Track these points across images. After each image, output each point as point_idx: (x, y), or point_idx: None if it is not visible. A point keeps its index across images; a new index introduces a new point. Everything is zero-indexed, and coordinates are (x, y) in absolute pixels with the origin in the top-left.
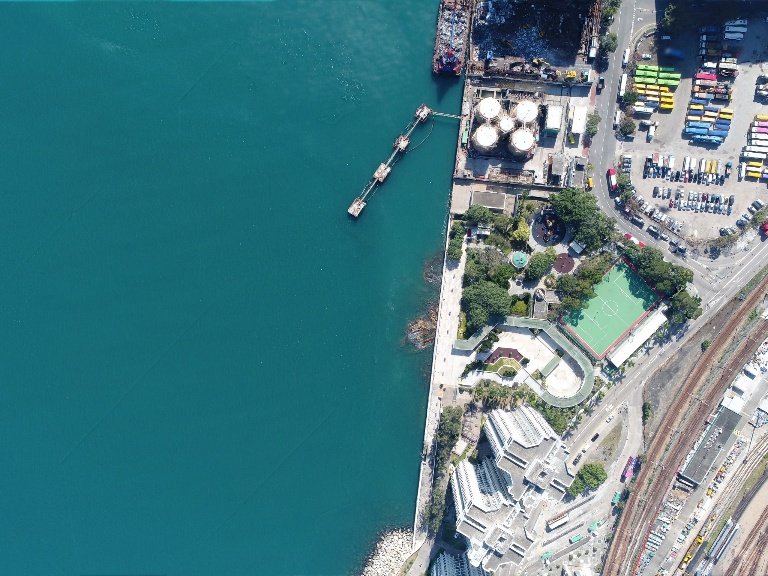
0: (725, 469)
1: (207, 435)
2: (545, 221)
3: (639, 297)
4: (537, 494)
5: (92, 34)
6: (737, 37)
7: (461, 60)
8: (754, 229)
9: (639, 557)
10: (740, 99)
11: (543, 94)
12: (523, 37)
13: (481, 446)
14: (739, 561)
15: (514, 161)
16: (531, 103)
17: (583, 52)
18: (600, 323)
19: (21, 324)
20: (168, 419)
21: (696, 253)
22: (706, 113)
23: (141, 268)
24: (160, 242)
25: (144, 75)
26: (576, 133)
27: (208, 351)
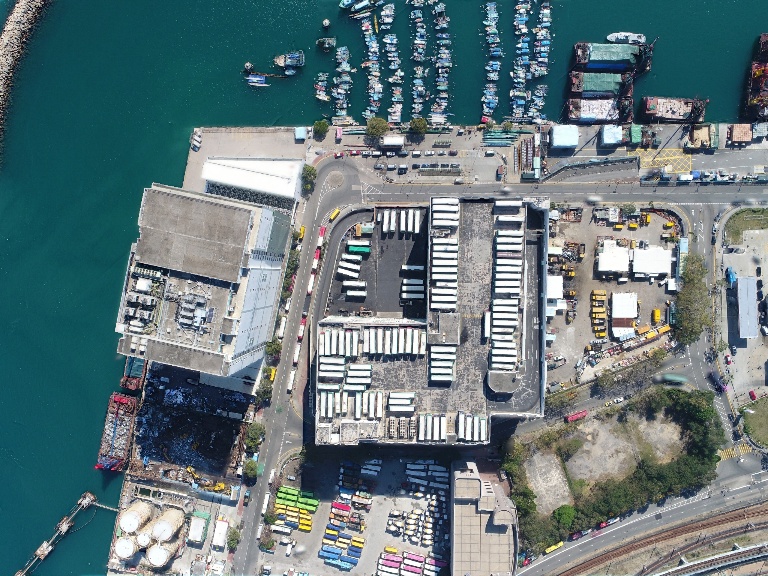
0: None
1: None
2: None
3: None
4: None
5: None
6: None
7: (123, 458)
8: None
9: None
10: (373, 528)
11: (194, 500)
12: (179, 446)
13: None
14: None
15: None
16: (167, 523)
17: (234, 466)
18: None
19: None
20: None
21: None
22: (339, 539)
23: None
24: None
25: None
26: None
27: None
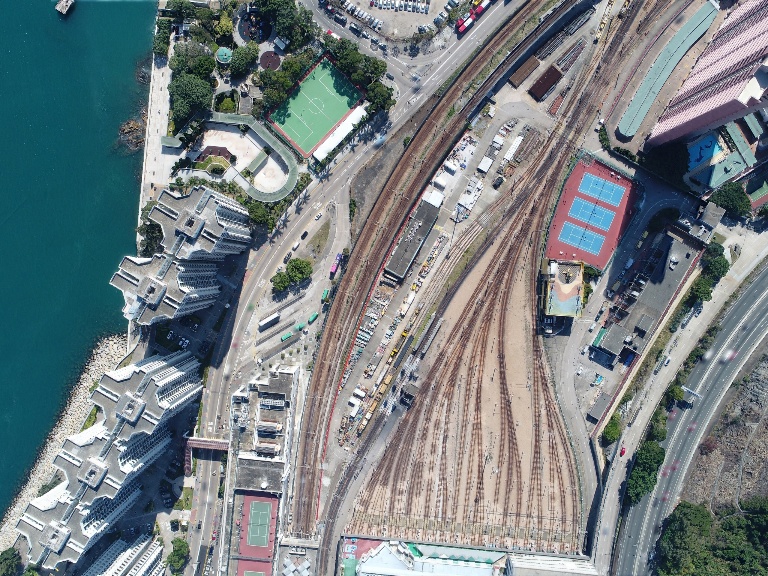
0: (429, 264)
1: None
2: None
3: (344, 95)
4: (189, 245)
5: None
6: None
7: None
8: (450, 27)
9: (349, 354)
10: None
11: None
12: None
13: None
14: (444, 355)
15: None
16: None
17: None
18: (307, 121)
19: None
20: None
21: (396, 51)
22: None
23: None
24: None
25: None
26: None
27: None
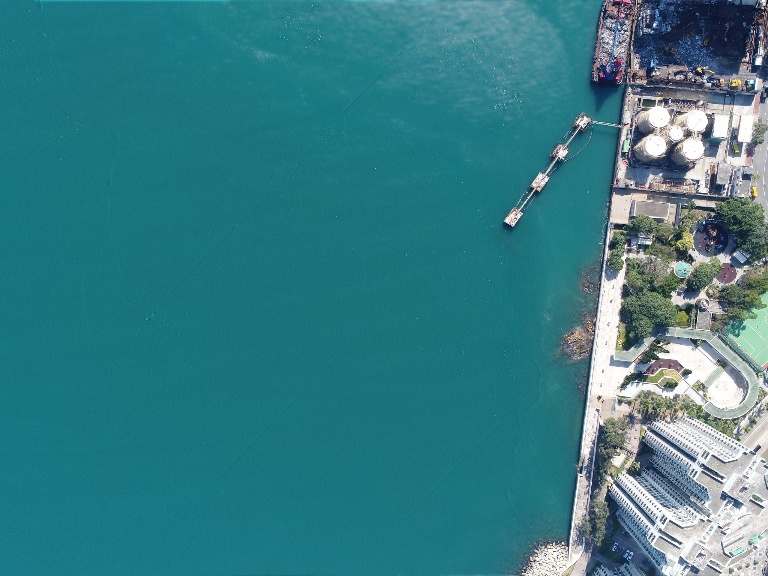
0: None
1: (369, 448)
2: (707, 231)
3: None
4: (735, 509)
5: (241, 43)
6: None
7: (622, 69)
8: None
9: None
10: None
11: (706, 103)
12: (687, 45)
13: (640, 458)
14: None
15: (676, 170)
16: (702, 112)
17: (747, 60)
18: (763, 333)
19: (180, 337)
20: (330, 432)
21: None
22: None
23: (304, 280)
24: (324, 253)
25: (308, 85)
26: (741, 142)
27: (371, 363)
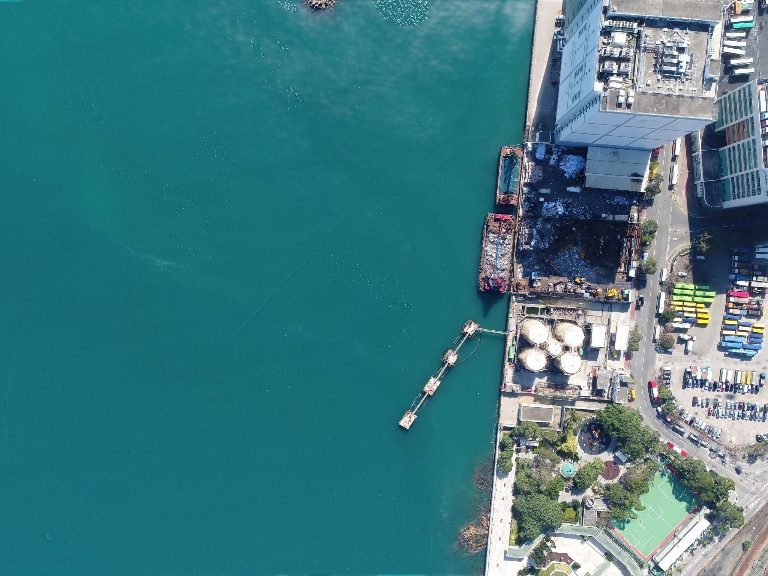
0: None
1: None
2: (591, 431)
3: (682, 501)
4: None
5: (139, 252)
6: (767, 257)
7: (506, 279)
8: None
9: None
10: None
11: (586, 311)
12: (565, 258)
13: None
14: None
15: (560, 374)
16: (578, 329)
17: (622, 270)
18: (646, 526)
19: (79, 556)
20: None
21: (735, 458)
22: (740, 328)
23: (201, 499)
24: (220, 474)
25: (200, 310)
26: None
27: None
